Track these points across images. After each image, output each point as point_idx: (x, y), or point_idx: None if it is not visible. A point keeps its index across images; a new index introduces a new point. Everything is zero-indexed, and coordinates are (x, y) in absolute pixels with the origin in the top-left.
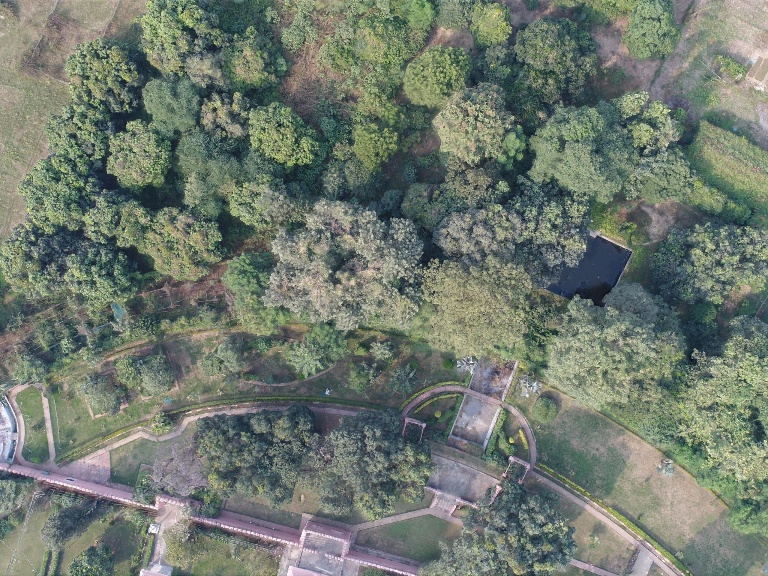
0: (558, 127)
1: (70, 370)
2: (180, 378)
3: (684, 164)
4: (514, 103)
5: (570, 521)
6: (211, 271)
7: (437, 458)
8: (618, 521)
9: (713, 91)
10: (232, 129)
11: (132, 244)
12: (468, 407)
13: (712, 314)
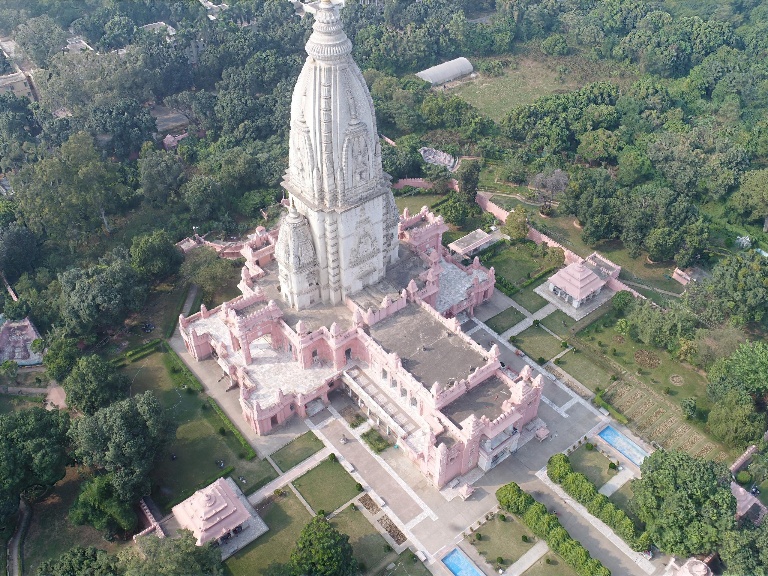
0: None
1: (500, 163)
2: None
3: None
4: None
5: None
6: None
7: (701, 270)
8: None
9: None
10: (656, 120)
11: (576, 132)
12: None
13: None
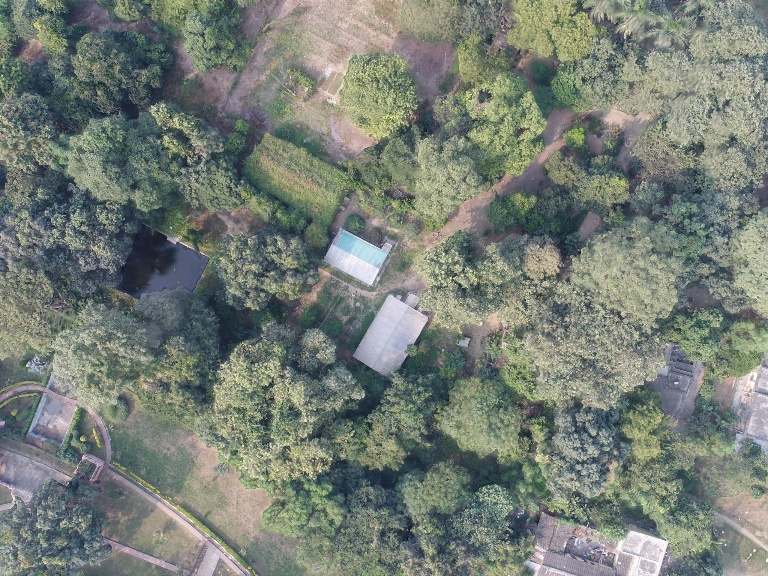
0: (80, 138)
1: None
2: None
3: (224, 175)
4: (63, 113)
5: (143, 518)
6: None
7: (13, 455)
8: (187, 518)
9: (288, 104)
10: None
11: None
12: (50, 406)
13: (268, 320)
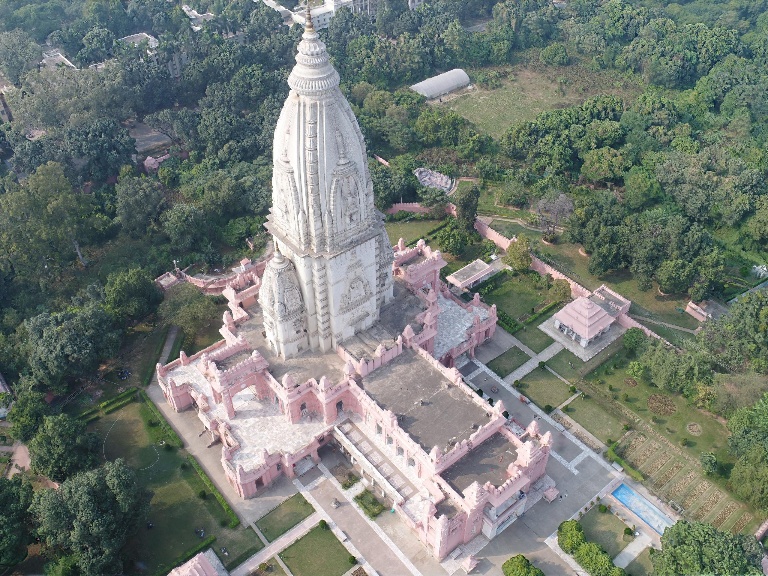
0: None
1: (499, 184)
2: None
3: None
4: None
5: None
6: None
7: (716, 303)
8: None
9: None
10: (663, 137)
11: (579, 150)
12: None
13: None
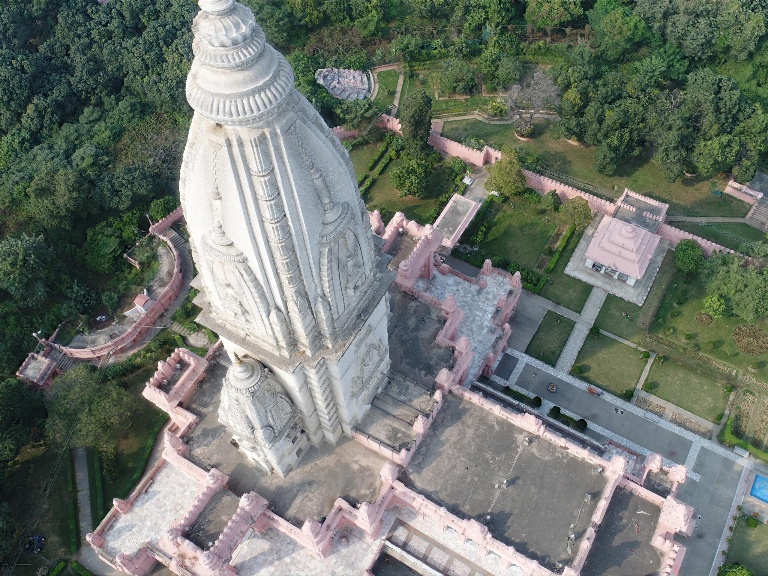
0: None
1: (430, 65)
2: (520, 89)
3: None
4: None
5: None
6: (561, 37)
7: (758, 173)
8: None
9: None
10: None
11: None
12: None
13: None
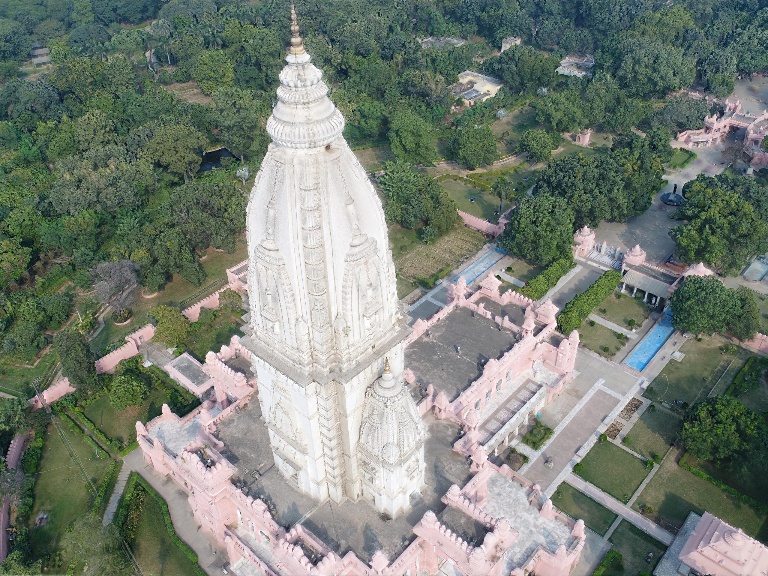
0: None
1: None
2: (71, 311)
3: None
4: None
5: None
6: (33, 276)
7: None
8: None
9: None
10: None
11: None
12: None
13: None
